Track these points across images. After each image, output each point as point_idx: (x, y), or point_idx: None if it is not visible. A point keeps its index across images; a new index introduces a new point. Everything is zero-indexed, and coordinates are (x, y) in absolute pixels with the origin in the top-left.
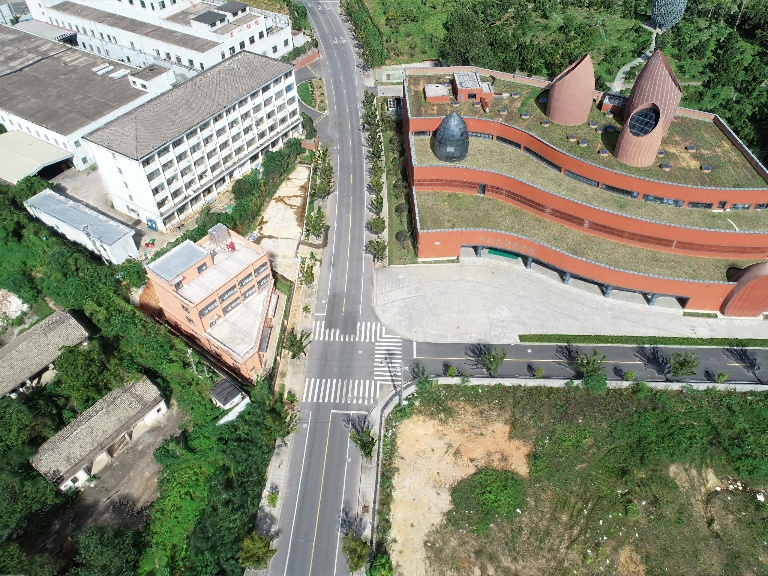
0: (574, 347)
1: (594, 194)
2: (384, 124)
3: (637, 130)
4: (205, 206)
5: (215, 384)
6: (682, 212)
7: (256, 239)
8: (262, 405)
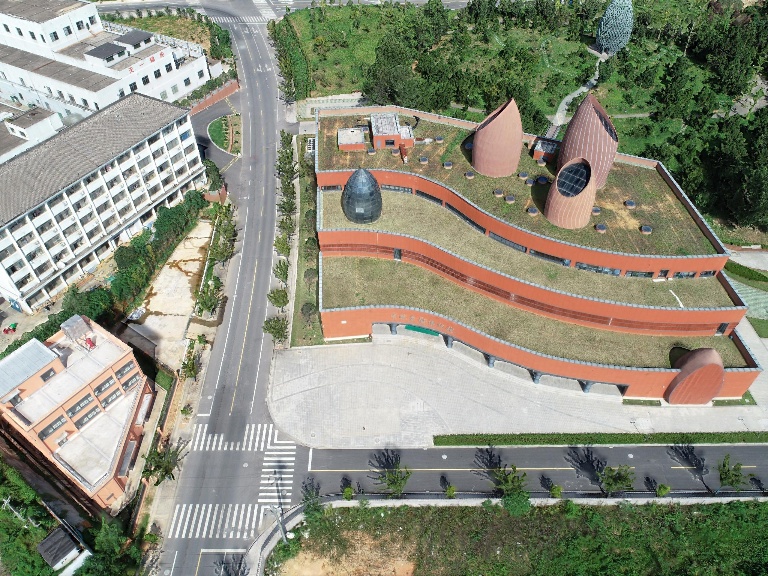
0: (496, 450)
1: (521, 261)
2: (301, 169)
3: (567, 189)
4: (81, 279)
5: (49, 532)
6: (619, 282)
7: (140, 317)
8: (107, 556)
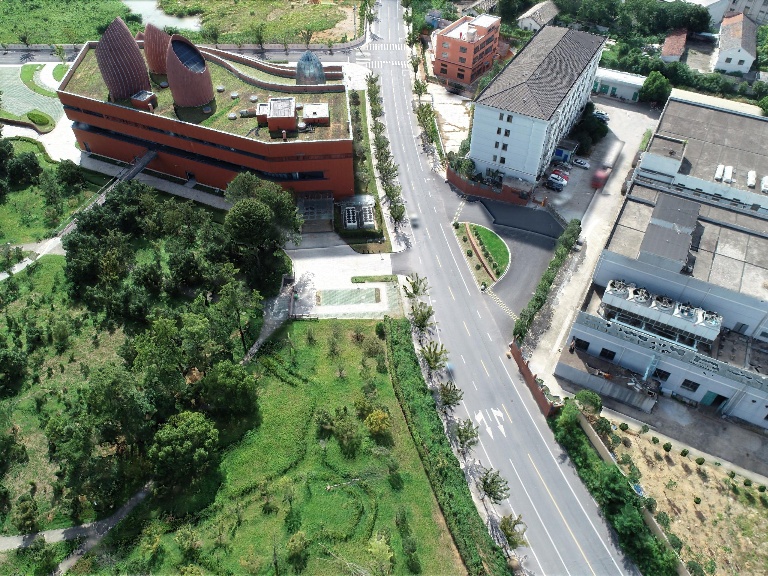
0: None
1: None
2: None
3: None
4: None
5: None
6: None
7: (466, 103)
8: None
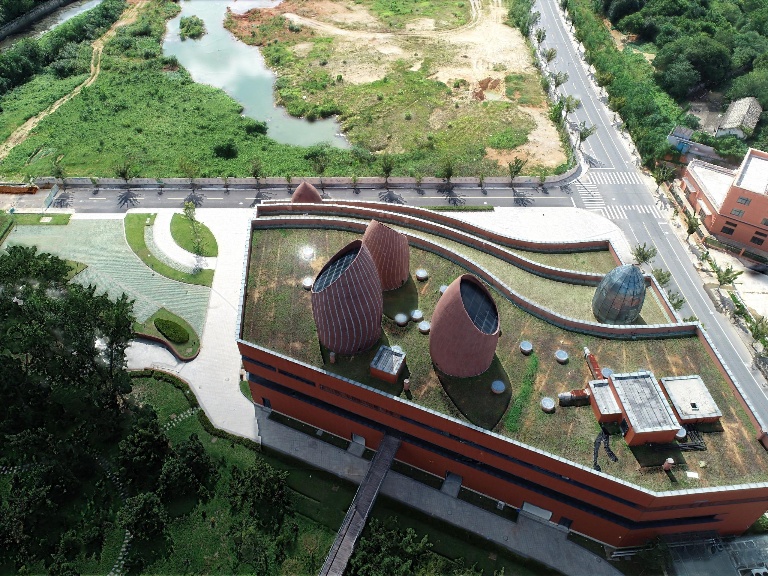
0: None
1: None
2: None
3: None
4: None
5: None
6: None
7: None
8: (659, 144)
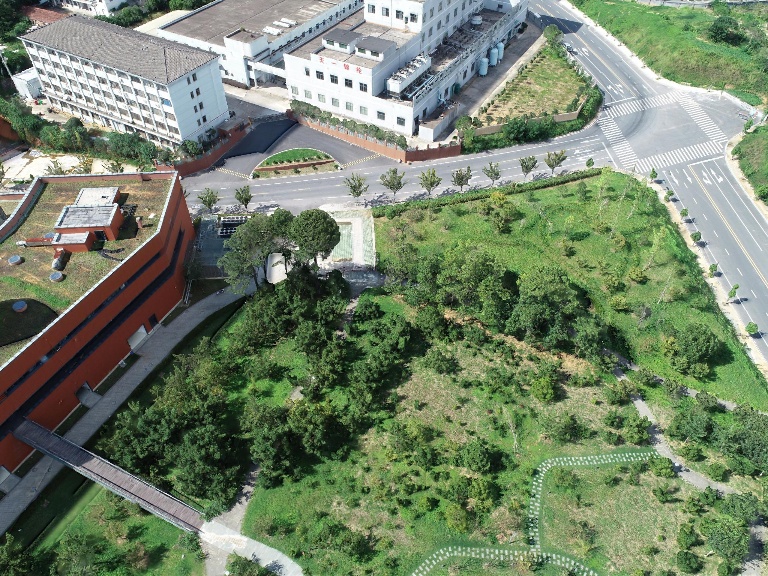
0: None
1: None
2: None
3: None
4: None
5: None
6: None
7: (31, 155)
8: None
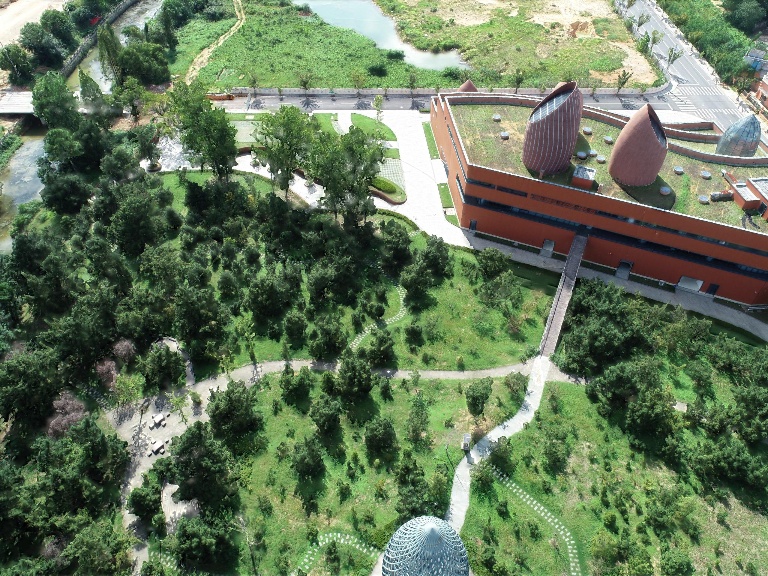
0: None
1: None
2: None
3: None
4: None
5: None
6: None
7: None
8: (736, 63)
